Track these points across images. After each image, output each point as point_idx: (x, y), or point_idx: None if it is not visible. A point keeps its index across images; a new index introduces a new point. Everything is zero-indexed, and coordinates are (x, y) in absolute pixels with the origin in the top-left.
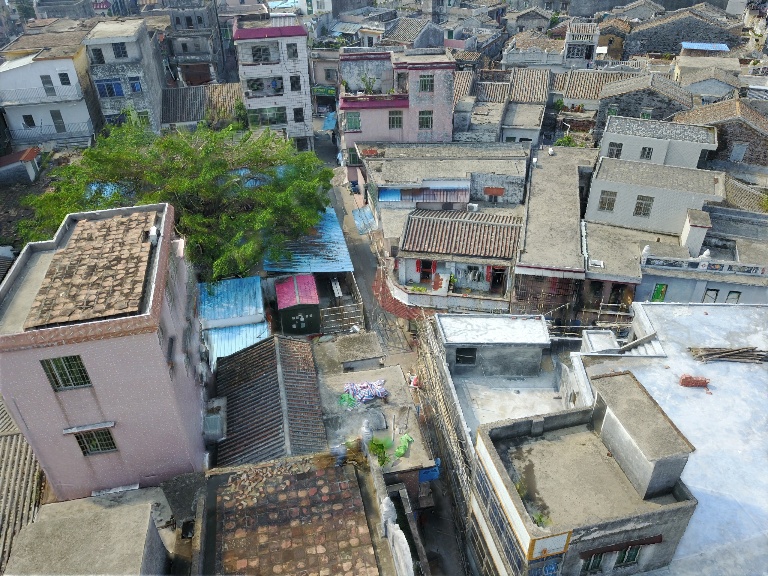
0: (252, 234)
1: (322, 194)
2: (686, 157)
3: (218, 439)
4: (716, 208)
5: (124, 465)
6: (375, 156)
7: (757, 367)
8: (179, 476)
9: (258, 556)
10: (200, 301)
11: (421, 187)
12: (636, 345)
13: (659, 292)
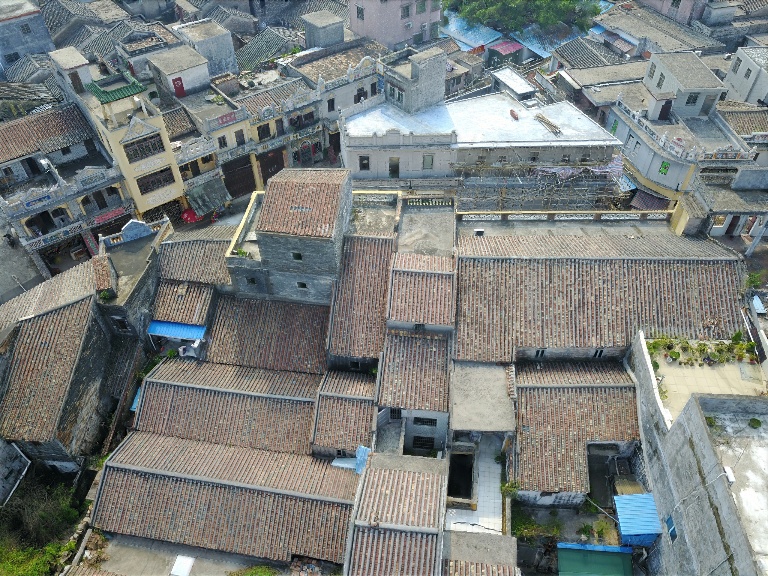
0: (510, 9)
1: (587, 20)
2: (764, 87)
3: (398, 50)
4: (718, 115)
5: (364, 29)
6: (625, 9)
7: (546, 131)
8: (368, 37)
9: (354, 54)
10: (472, 30)
11: (617, 33)
12: (533, 106)
13: (615, 126)
